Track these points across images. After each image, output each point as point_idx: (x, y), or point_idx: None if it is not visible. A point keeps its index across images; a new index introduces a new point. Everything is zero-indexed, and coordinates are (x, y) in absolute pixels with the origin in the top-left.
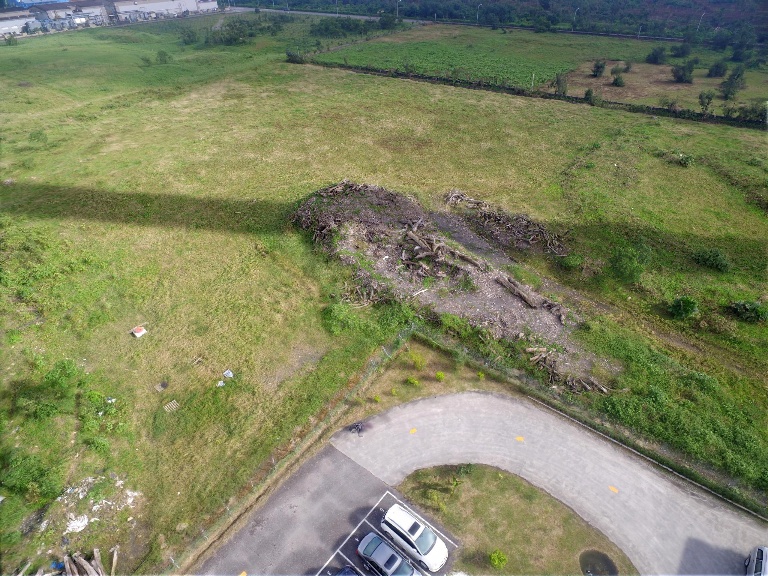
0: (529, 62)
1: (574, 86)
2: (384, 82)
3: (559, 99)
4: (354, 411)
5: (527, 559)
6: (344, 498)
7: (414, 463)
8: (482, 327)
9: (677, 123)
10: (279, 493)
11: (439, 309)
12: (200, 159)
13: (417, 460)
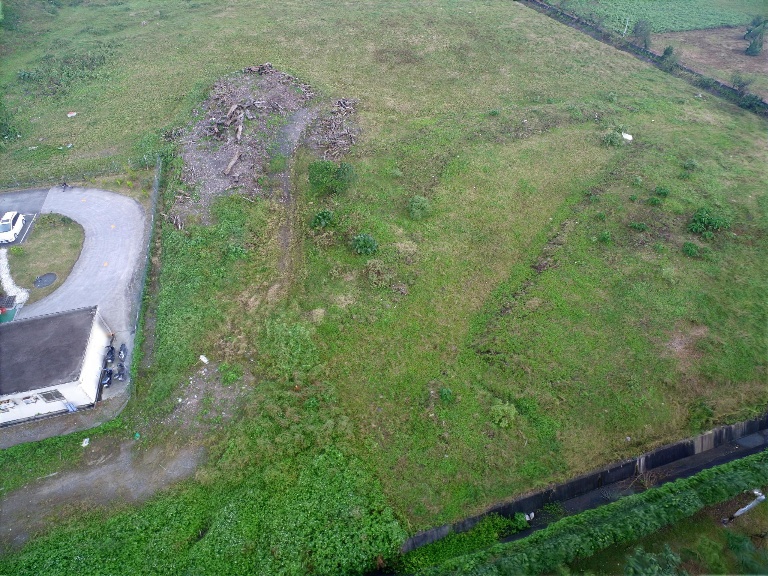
0: (696, 8)
1: (687, 43)
2: (492, 2)
3: (636, 53)
4: (80, 182)
5: (31, 261)
6: (21, 207)
7: (62, 211)
8: (183, 171)
9: (715, 108)
10: (8, 193)
11: (183, 154)
12: (250, 34)
13: (64, 210)
